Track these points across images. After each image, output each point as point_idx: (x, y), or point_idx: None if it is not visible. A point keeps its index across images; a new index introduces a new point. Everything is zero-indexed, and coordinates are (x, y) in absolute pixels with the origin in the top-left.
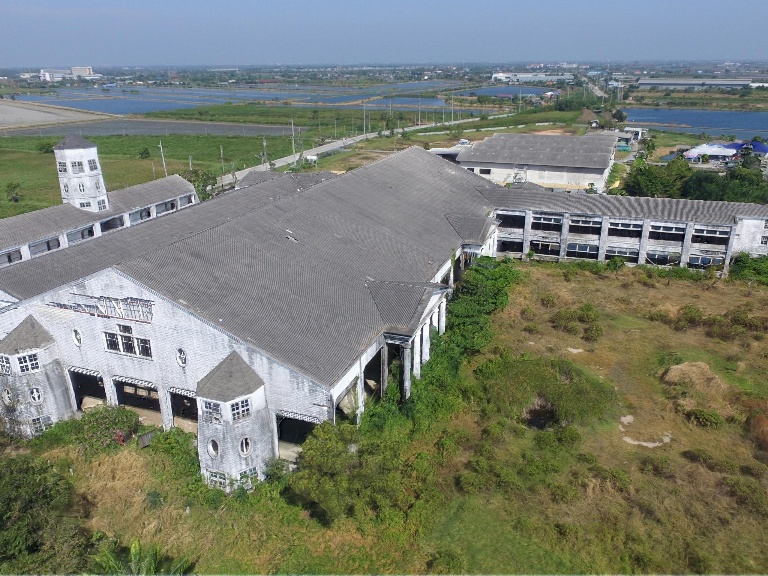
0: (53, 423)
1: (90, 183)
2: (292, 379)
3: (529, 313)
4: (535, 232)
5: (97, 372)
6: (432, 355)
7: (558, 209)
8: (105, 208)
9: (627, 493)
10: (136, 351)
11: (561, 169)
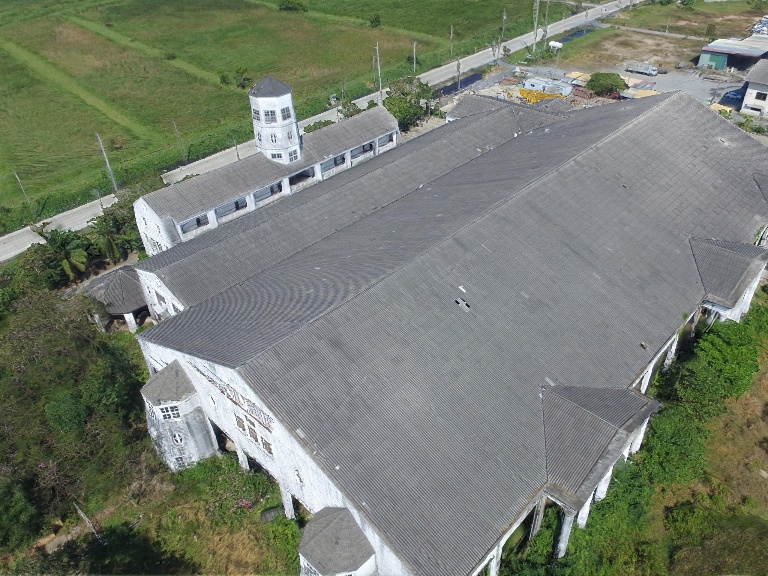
0: (194, 461)
1: (282, 134)
2: (403, 570)
3: None
4: None
5: (230, 435)
6: (610, 492)
7: None
8: (297, 158)
9: None
10: (260, 444)
11: None
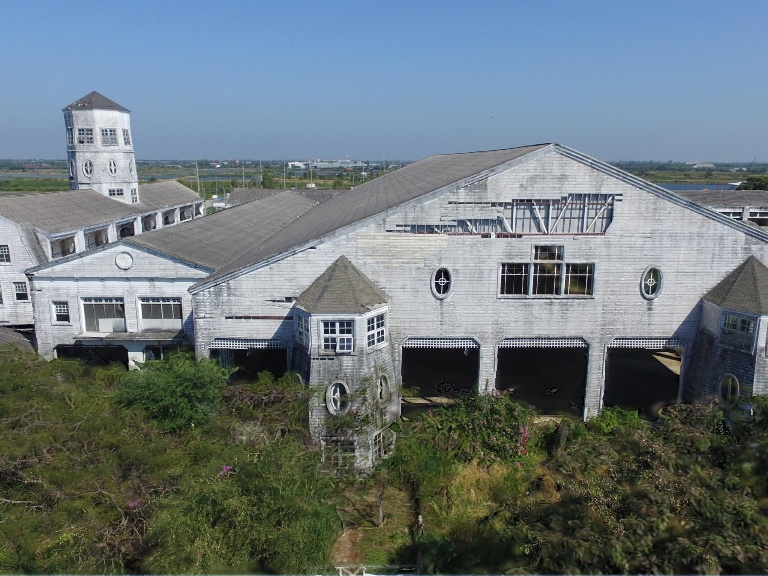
0: (392, 442)
1: (124, 161)
2: None
3: None
4: None
5: (467, 340)
6: None
7: None
8: (136, 201)
9: None
10: (562, 287)
11: None
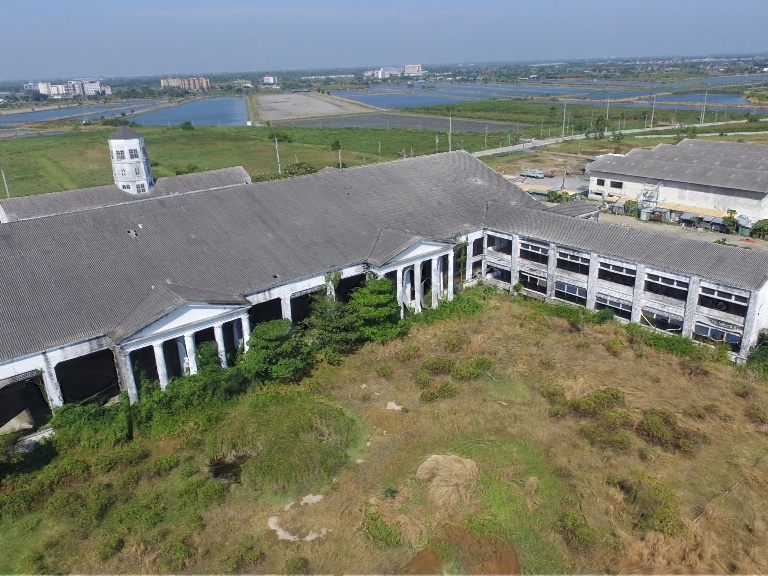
0: None
1: (130, 169)
2: None
3: (403, 352)
4: (523, 261)
5: None
6: (201, 371)
7: (548, 237)
8: (145, 191)
9: (160, 574)
10: None
11: (706, 189)
